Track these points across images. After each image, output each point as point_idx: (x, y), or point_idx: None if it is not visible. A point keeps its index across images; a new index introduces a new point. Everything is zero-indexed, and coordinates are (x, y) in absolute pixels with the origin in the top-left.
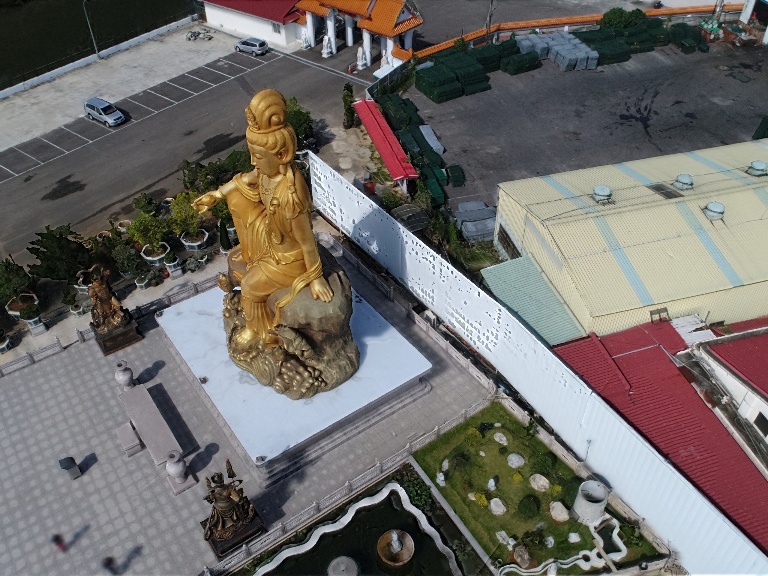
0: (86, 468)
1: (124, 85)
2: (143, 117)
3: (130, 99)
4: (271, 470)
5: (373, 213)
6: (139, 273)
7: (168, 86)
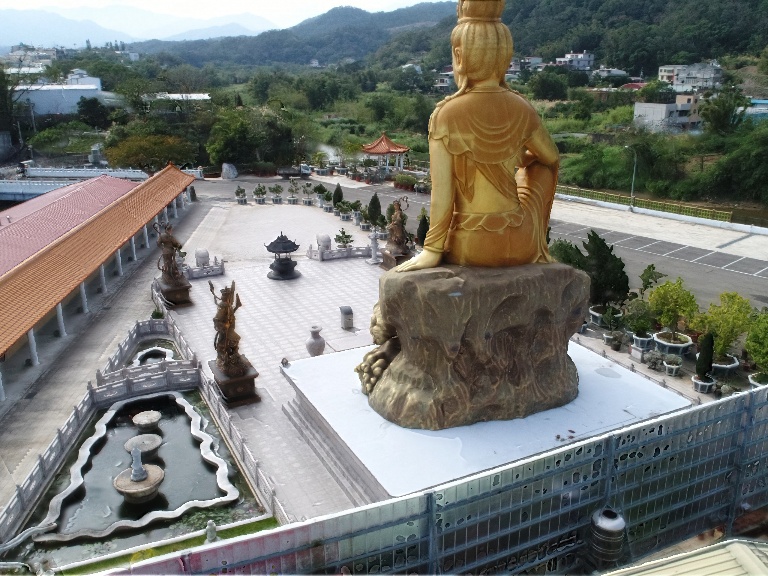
0: (352, 331)
1: None
2: None
3: None
4: (296, 400)
5: None
6: (614, 324)
7: None
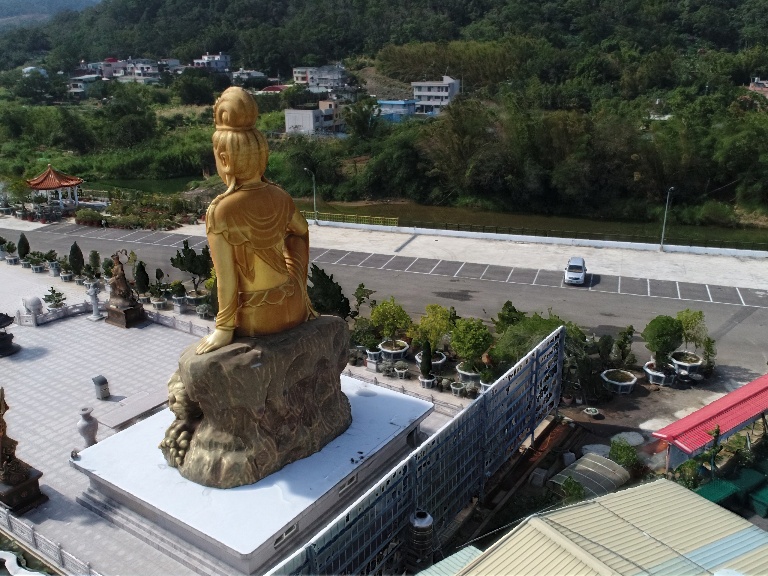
0: (110, 399)
1: (639, 269)
2: (601, 290)
3: (621, 278)
4: (92, 489)
5: (491, 400)
6: None
7: (671, 284)
